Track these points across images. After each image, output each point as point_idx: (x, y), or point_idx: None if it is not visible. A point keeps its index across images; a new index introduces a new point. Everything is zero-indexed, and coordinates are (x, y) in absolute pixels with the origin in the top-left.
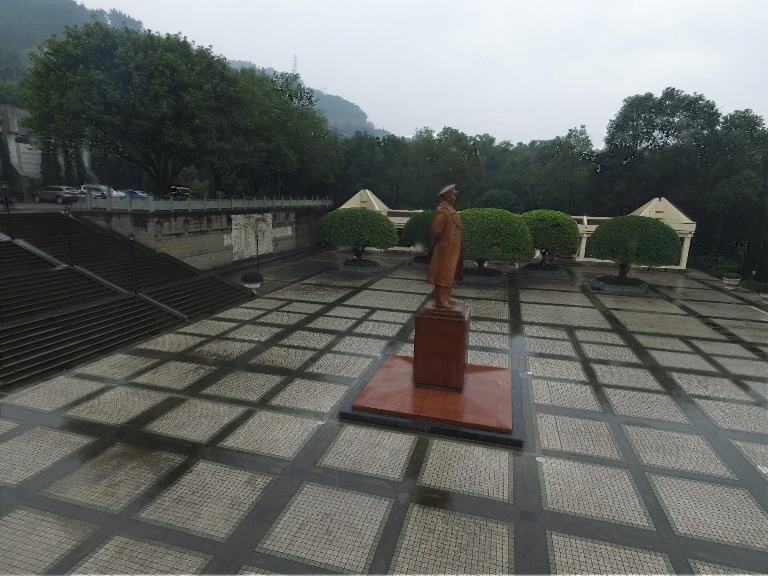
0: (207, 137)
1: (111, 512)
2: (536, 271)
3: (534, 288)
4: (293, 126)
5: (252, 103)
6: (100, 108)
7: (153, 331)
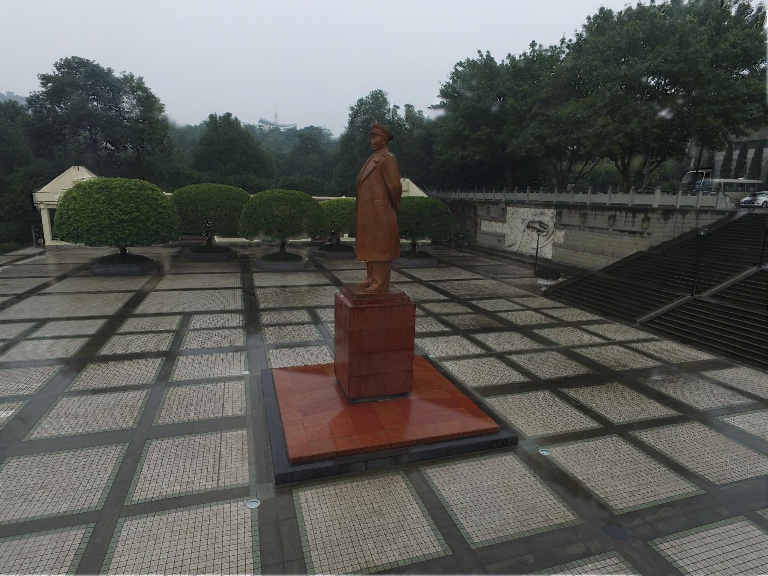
0: None
1: None
2: None
3: None
4: None
5: None
6: None
7: None
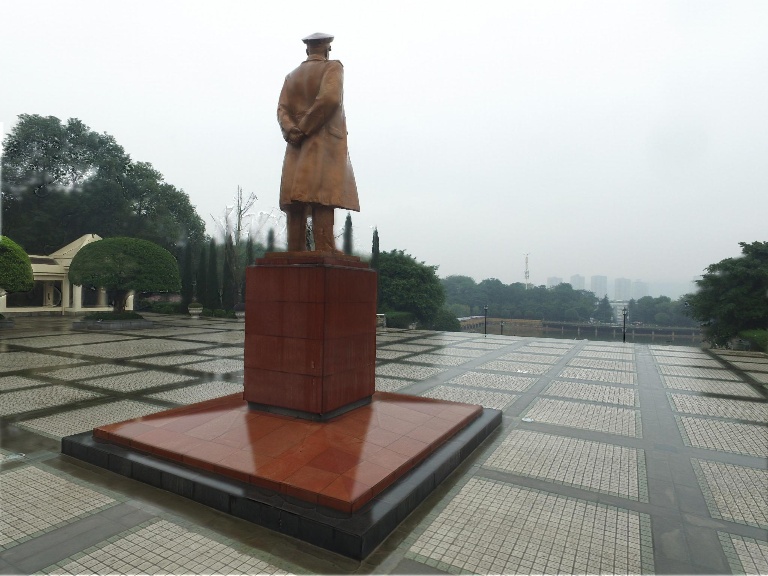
0: None
1: None
2: None
3: (11, 338)
4: None
5: None
6: None
7: None
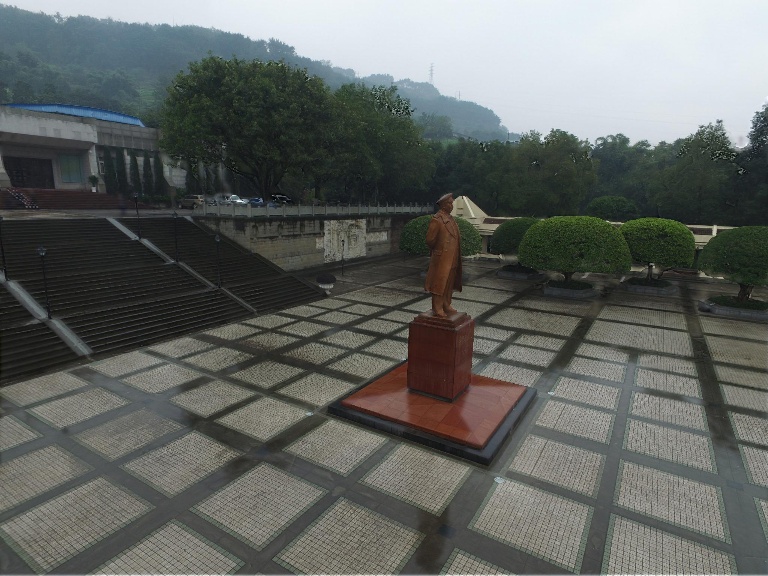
0: (293, 150)
1: (108, 459)
2: (638, 286)
3: (625, 305)
4: (383, 136)
5: (339, 117)
6: (207, 129)
7: (223, 321)
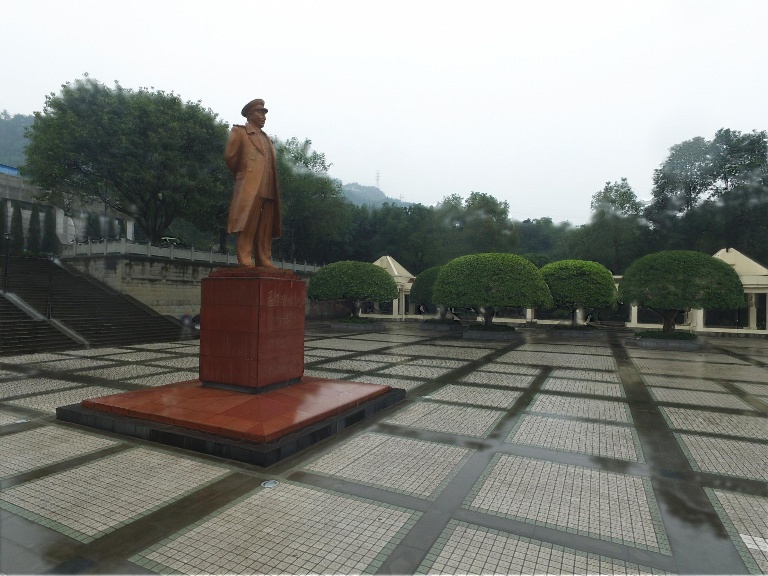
0: (173, 174)
1: None
2: (563, 331)
3: (548, 343)
4: (292, 182)
5: None
6: (68, 146)
7: (29, 350)
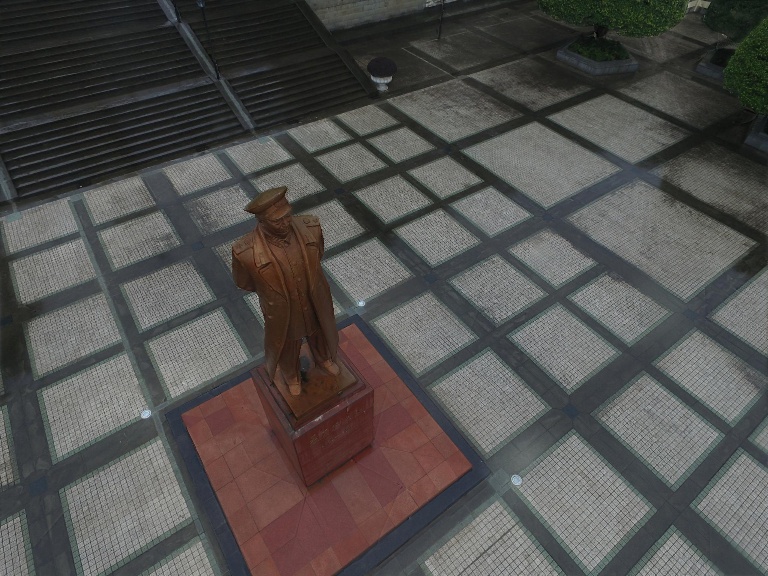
0: None
1: None
2: None
3: None
4: None
5: None
6: None
7: (200, 145)
